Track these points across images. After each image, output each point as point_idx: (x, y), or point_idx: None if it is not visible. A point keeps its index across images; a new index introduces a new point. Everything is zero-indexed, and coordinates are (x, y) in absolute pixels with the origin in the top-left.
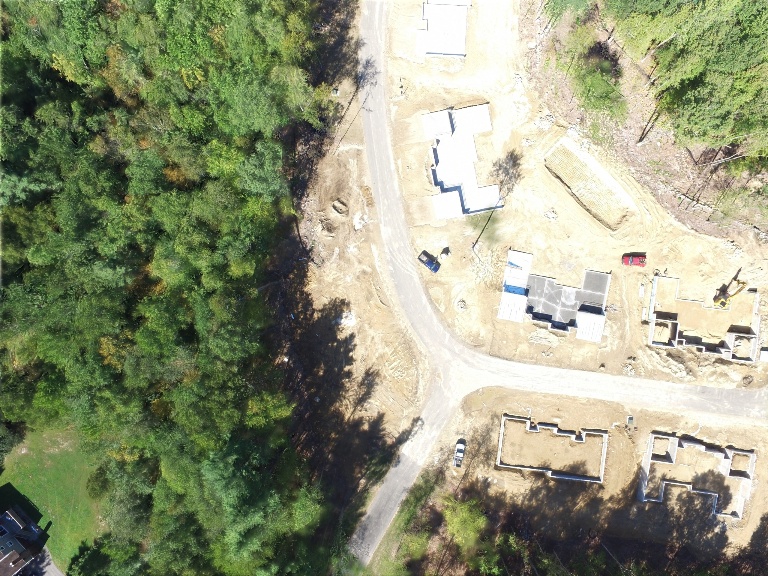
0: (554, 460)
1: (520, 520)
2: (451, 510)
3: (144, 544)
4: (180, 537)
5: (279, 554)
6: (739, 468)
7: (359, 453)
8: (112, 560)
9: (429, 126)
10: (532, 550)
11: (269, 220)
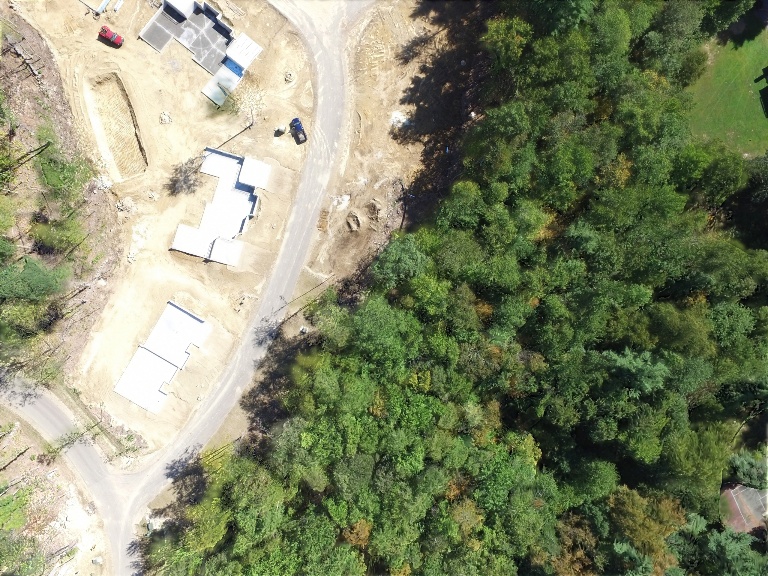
0: None
1: None
2: None
3: None
4: None
5: None
6: None
7: None
8: None
9: (235, 254)
10: None
11: None
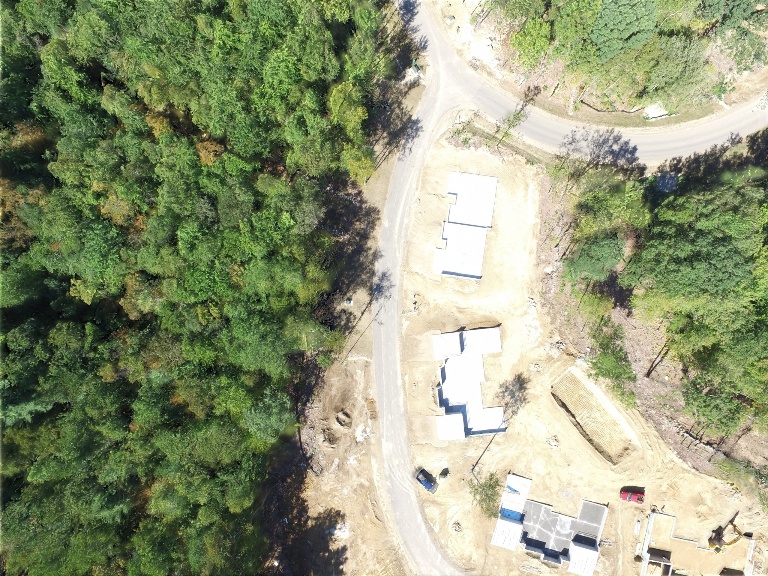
0: None
1: None
2: None
3: None
4: None
5: None
6: None
7: None
8: None
9: (439, 346)
10: None
11: None
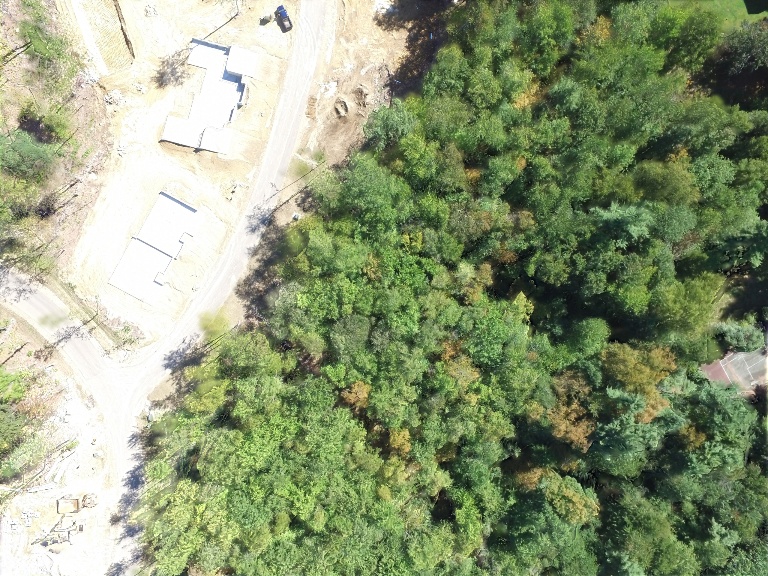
0: None
1: None
2: None
3: None
4: None
5: None
6: None
7: None
8: None
9: (224, 142)
10: None
11: None
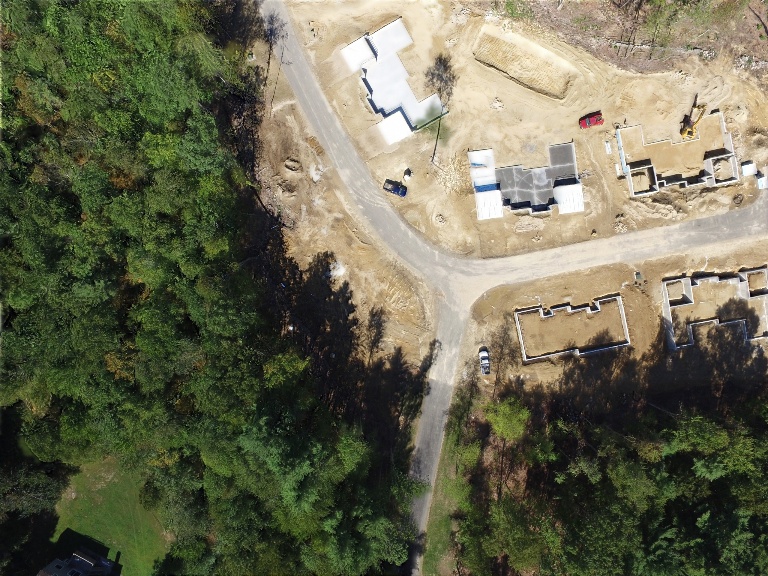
0: (577, 338)
1: (563, 405)
2: (492, 412)
3: (212, 538)
4: (241, 516)
5: (339, 500)
6: (758, 287)
7: (389, 392)
8: (187, 562)
9: (351, 58)
10: (584, 429)
11: (228, 198)
